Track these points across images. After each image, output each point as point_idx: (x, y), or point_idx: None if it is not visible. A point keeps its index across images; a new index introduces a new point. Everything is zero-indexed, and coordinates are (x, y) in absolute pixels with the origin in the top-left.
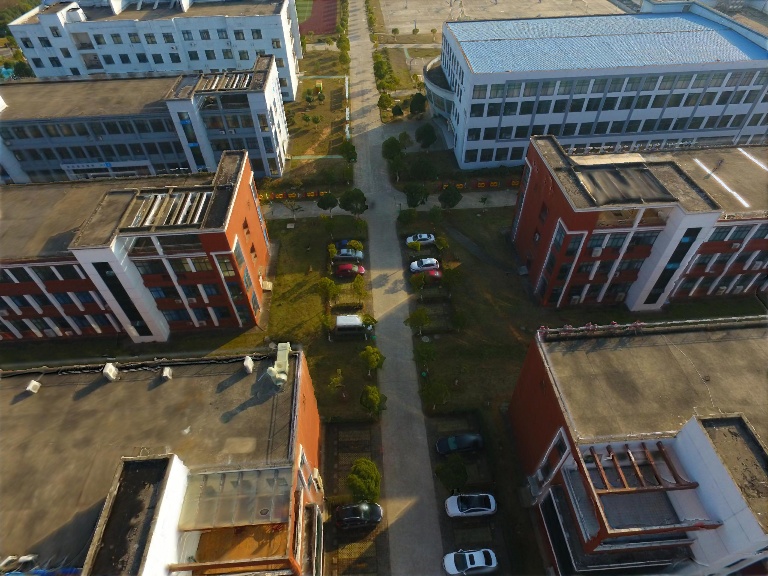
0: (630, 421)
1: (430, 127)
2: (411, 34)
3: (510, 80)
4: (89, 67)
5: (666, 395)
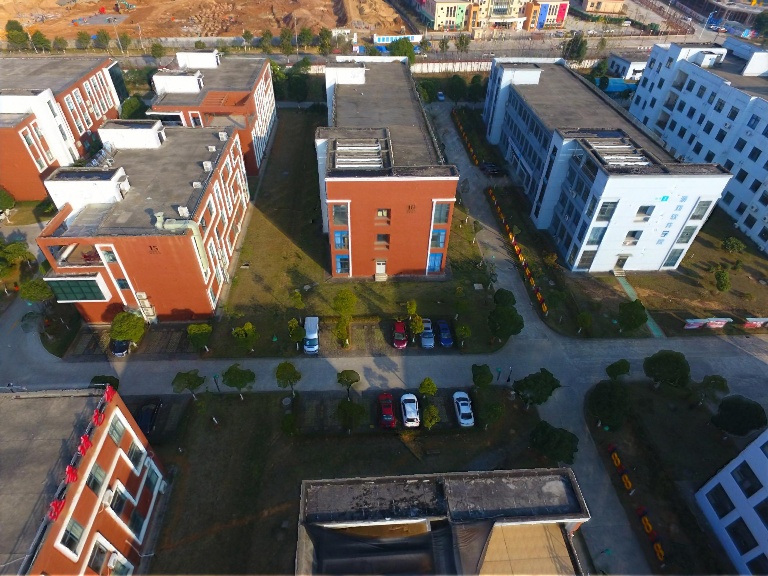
0: None
1: (750, 411)
2: None
3: None
4: (668, 105)
5: None
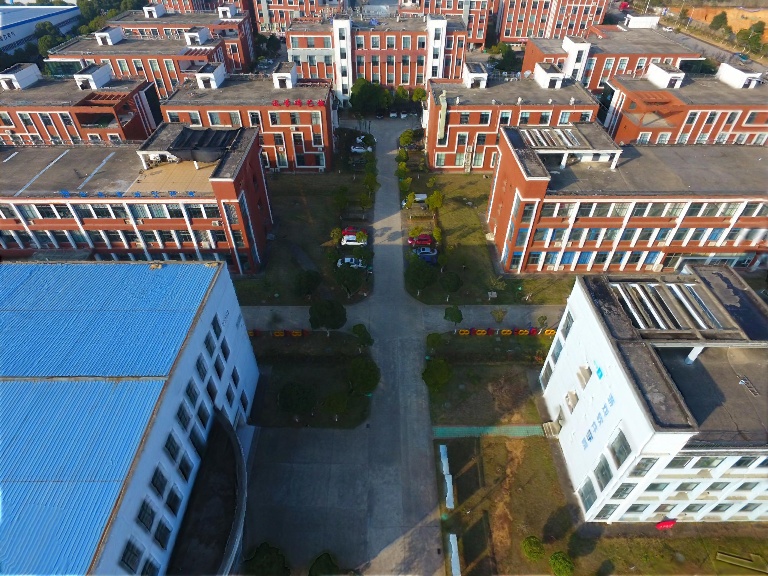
0: None
1: (289, 384)
2: None
3: None
4: None
5: (284, 94)
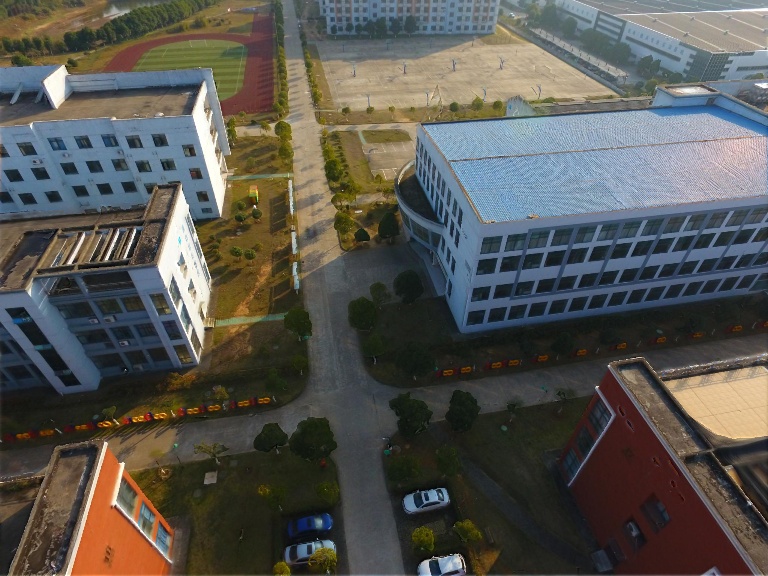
0: None
1: (414, 277)
2: (364, 111)
3: (534, 228)
4: None
5: None
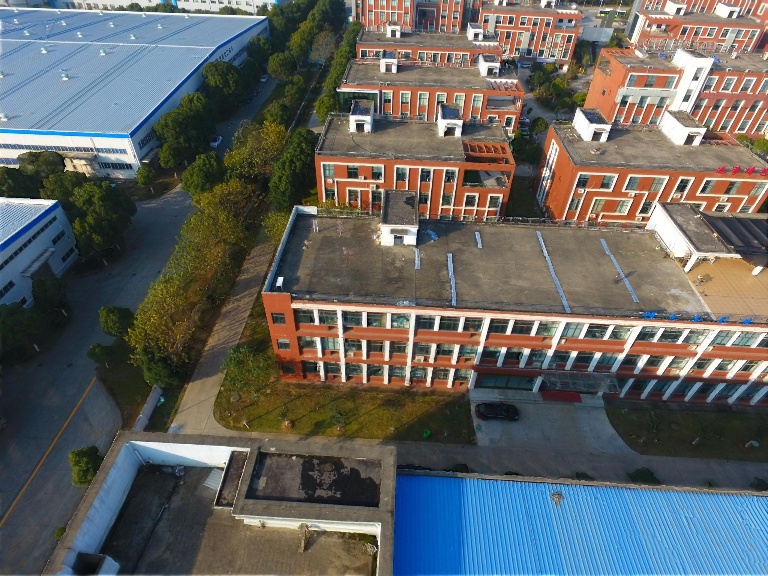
0: (719, 150)
1: None
2: None
3: None
4: None
5: (701, 154)
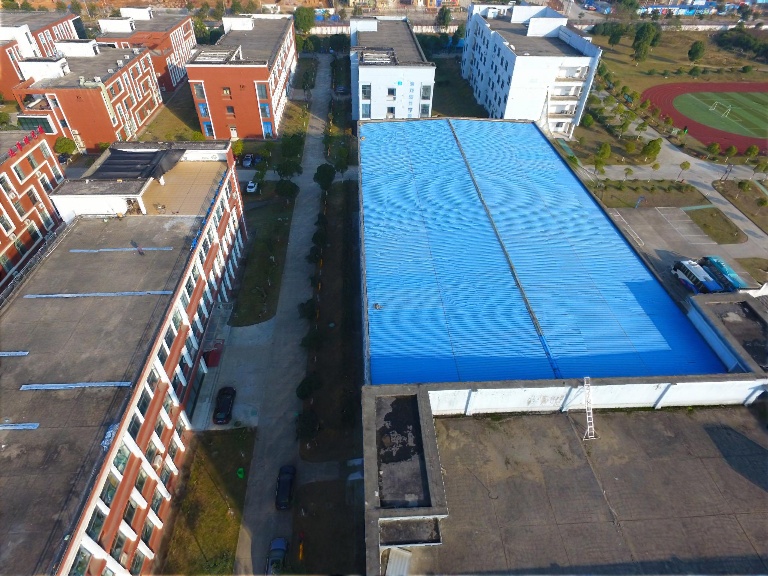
0: None
1: None
2: None
3: None
4: None
5: None
